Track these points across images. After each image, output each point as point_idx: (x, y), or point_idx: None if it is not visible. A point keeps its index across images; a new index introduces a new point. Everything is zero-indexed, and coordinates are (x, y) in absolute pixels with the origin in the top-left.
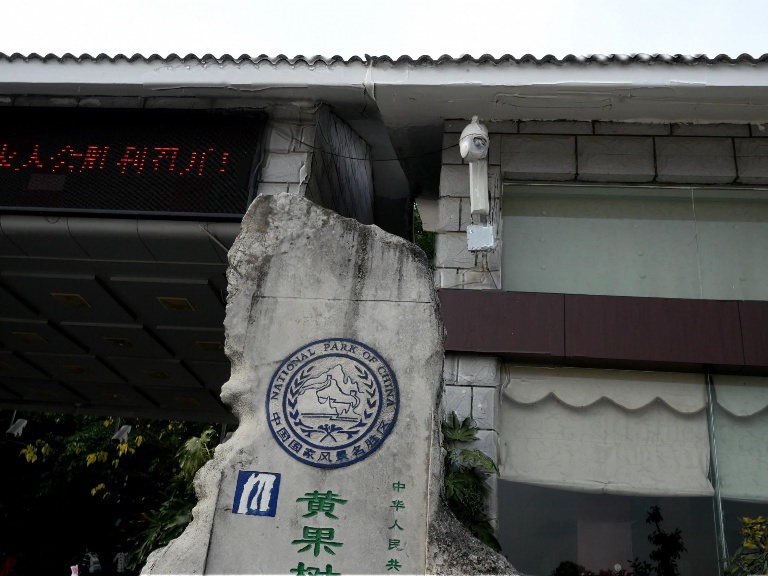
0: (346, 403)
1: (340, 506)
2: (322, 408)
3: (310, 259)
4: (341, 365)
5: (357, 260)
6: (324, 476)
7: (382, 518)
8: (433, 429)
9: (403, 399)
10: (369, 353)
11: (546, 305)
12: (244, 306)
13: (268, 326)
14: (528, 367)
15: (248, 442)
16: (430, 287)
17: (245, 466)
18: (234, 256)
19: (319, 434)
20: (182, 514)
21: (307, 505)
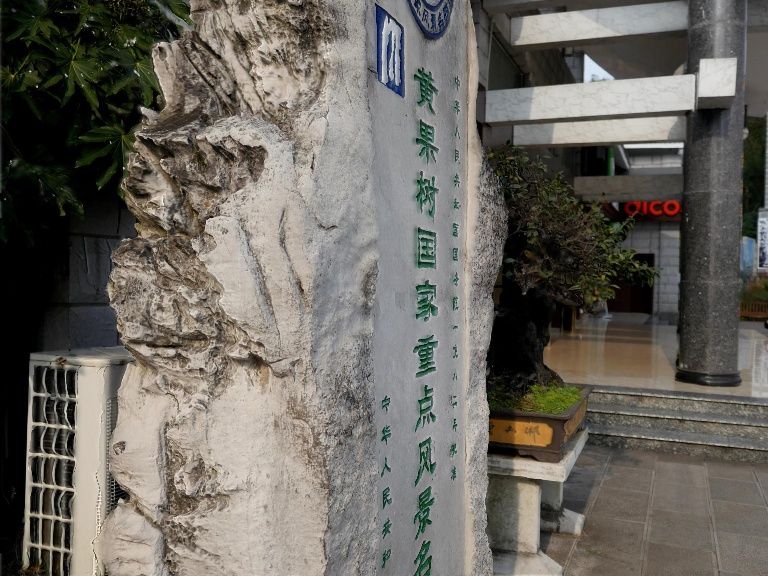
0: None
1: None
2: None
3: None
4: None
5: None
6: None
7: None
8: None
9: None
10: None
11: None
12: None
13: None
14: None
15: None
16: None
17: None
18: None
19: None
20: None
21: (420, 88)
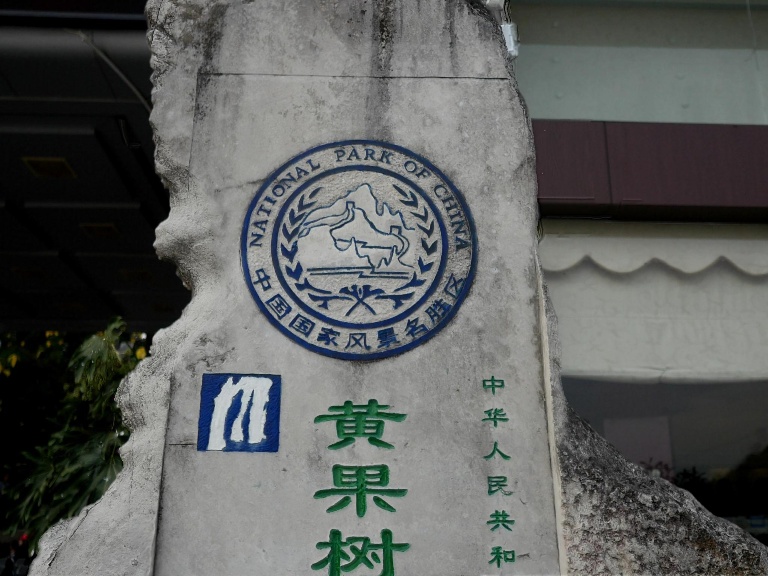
0: (385, 248)
1: (394, 425)
2: (343, 258)
3: (294, 11)
4: (369, 184)
5: (376, 12)
6: (360, 374)
7: (471, 441)
8: (543, 284)
9: (483, 237)
10: (415, 163)
11: (583, 134)
12: (184, 90)
13: (231, 123)
14: (566, 217)
15: (214, 323)
16: (504, 54)
17: (213, 365)
18: (157, 8)
19: (343, 303)
20: (90, 447)
21: (335, 427)
